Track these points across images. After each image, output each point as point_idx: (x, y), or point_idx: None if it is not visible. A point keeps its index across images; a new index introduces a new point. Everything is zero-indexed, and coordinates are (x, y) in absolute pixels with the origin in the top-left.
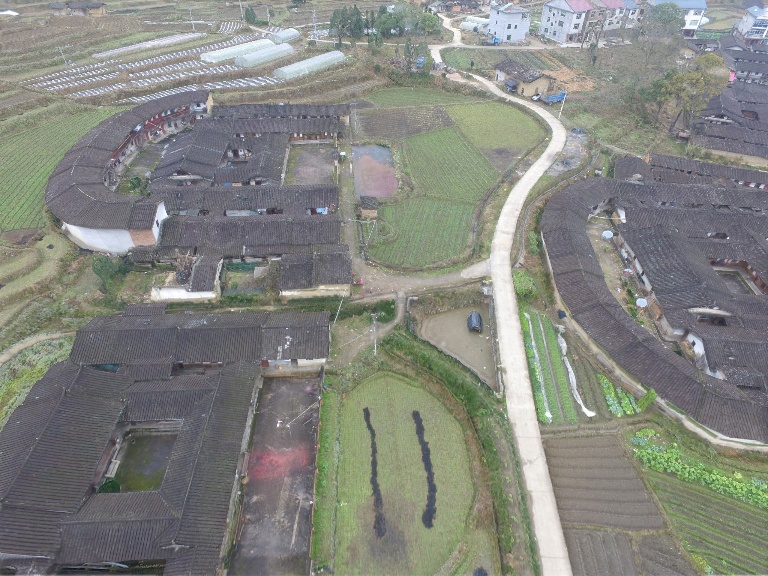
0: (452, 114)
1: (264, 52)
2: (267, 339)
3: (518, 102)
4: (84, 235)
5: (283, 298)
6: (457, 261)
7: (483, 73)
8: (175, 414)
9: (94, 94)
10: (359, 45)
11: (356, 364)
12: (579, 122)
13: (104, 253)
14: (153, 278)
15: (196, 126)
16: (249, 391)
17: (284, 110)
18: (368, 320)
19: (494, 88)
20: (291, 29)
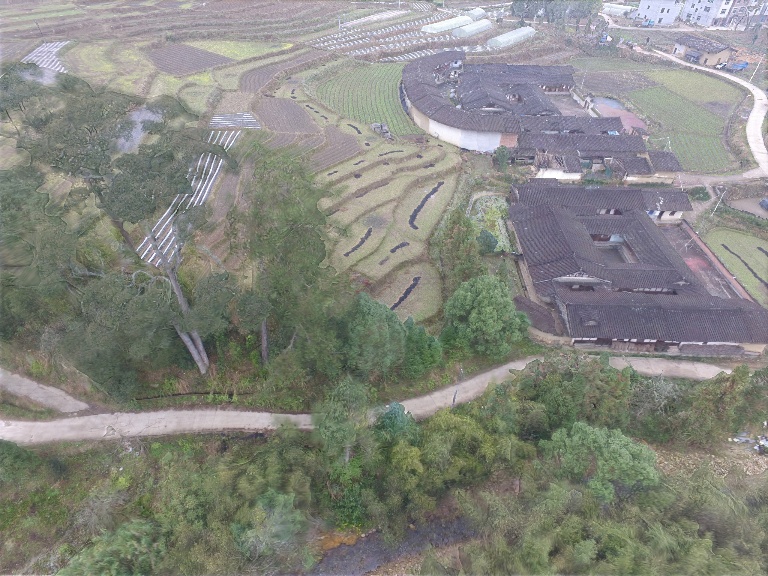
0: (651, 77)
1: (475, 25)
2: (647, 198)
3: (704, 70)
4: (462, 138)
5: (625, 183)
6: (733, 169)
7: (658, 48)
8: (617, 232)
9: (364, 53)
10: (537, 23)
11: (701, 221)
12: (766, 86)
13: (478, 151)
14: (519, 169)
15: (464, 77)
16: (654, 224)
17: (520, 69)
18: (691, 199)
19: (676, 59)
20: (479, 9)
